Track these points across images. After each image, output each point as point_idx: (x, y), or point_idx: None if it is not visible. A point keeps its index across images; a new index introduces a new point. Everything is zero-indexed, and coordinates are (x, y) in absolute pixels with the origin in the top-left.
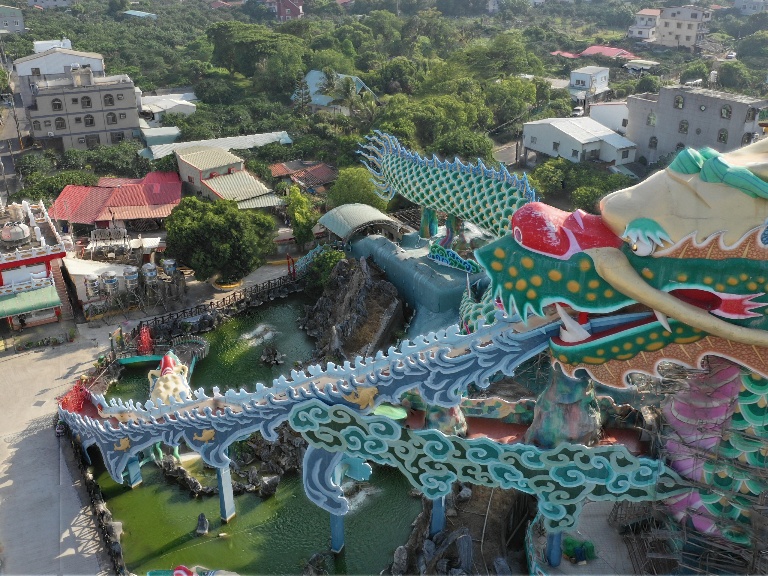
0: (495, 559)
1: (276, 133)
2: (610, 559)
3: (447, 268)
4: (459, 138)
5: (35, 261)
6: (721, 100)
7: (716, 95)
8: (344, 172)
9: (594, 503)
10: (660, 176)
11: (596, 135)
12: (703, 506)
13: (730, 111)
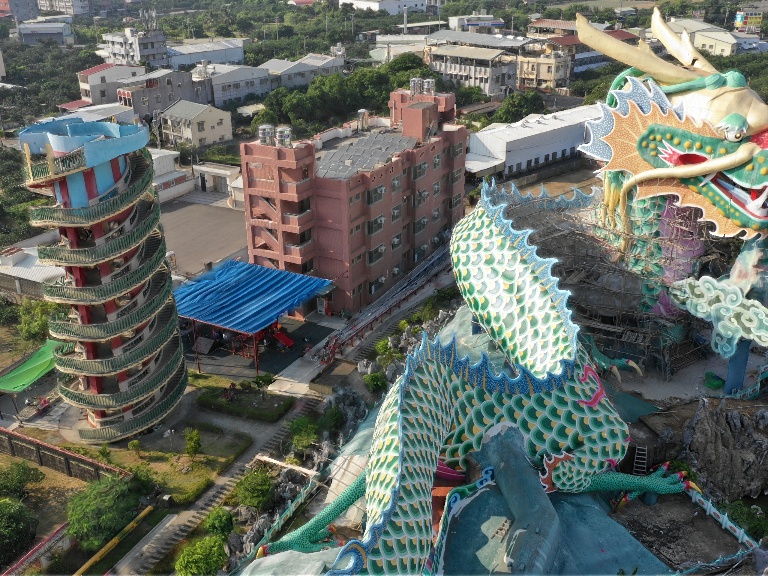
0: None
1: None
2: (700, 373)
3: (453, 569)
4: None
5: None
6: None
7: None
8: None
9: (662, 391)
10: (752, 92)
11: None
12: None
13: None
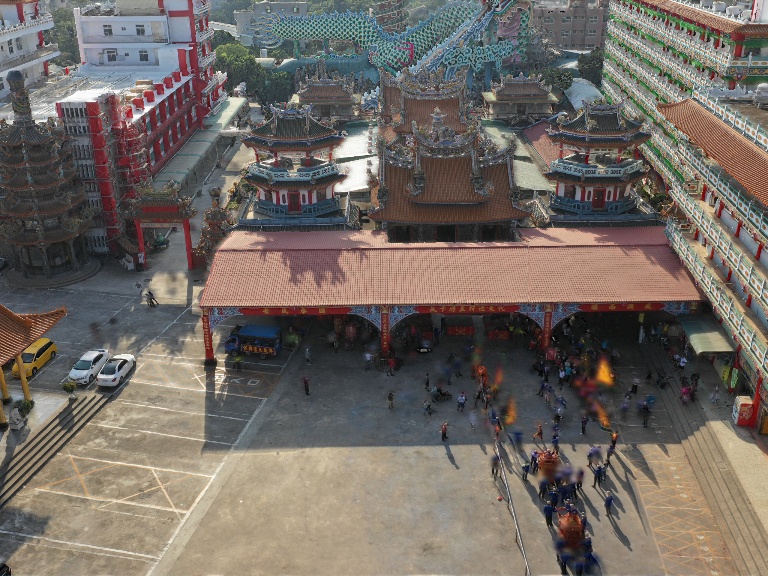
0: (489, 87)
1: (52, 66)
2: None
3: None
4: (225, 32)
5: (223, 83)
6: (292, 4)
7: (285, 2)
8: (224, 47)
9: None
10: None
11: (236, 34)
12: (518, 53)
13: (298, 8)
